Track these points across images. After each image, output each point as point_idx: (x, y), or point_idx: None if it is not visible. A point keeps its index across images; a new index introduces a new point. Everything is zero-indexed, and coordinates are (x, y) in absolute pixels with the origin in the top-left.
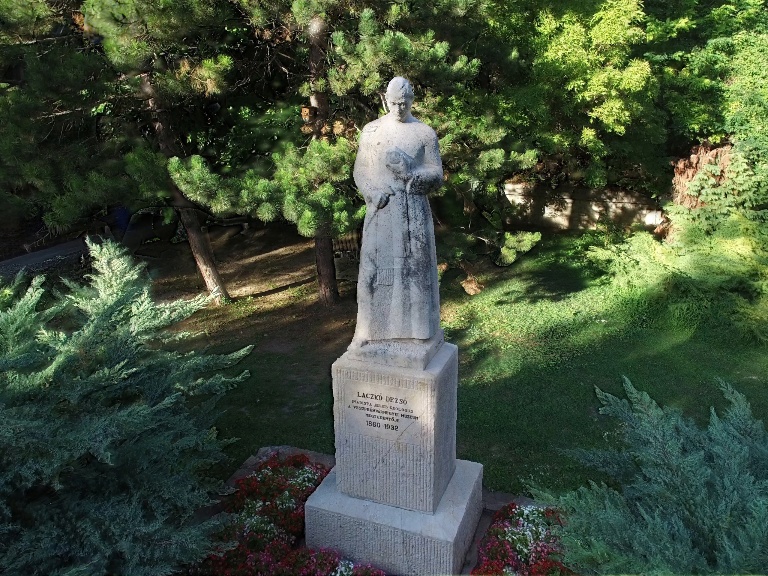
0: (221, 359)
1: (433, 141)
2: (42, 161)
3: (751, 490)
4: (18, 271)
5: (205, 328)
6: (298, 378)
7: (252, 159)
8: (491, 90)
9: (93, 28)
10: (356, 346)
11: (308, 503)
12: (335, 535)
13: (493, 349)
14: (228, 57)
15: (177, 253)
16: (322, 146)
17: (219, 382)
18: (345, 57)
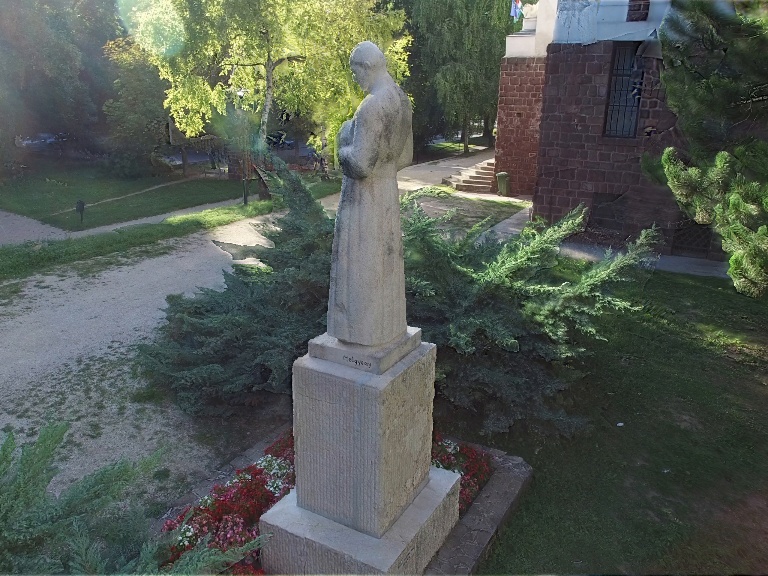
0: None
1: None
2: None
3: None
4: None
5: None
6: (757, 507)
7: None
8: None
9: (752, 1)
10: None
11: None
12: None
13: None
14: None
15: None
16: None
17: None
18: None
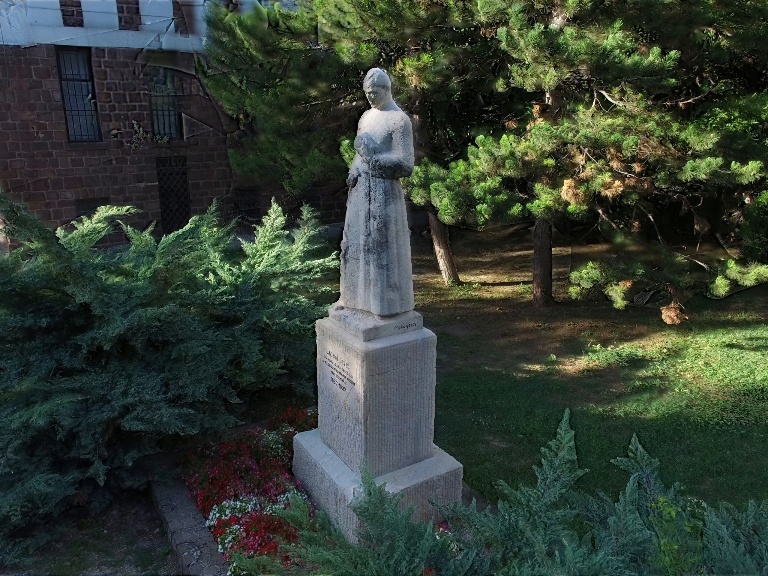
0: (315, 309)
1: (400, 129)
2: (297, 140)
3: (601, 572)
4: (235, 217)
5: (418, 301)
6: (446, 359)
7: (467, 151)
8: (761, 89)
9: (327, 34)
10: (332, 309)
11: (297, 436)
12: (306, 470)
13: (665, 388)
14: (429, 55)
15: (458, 237)
16: (500, 141)
17: (294, 324)
18: (512, 52)
